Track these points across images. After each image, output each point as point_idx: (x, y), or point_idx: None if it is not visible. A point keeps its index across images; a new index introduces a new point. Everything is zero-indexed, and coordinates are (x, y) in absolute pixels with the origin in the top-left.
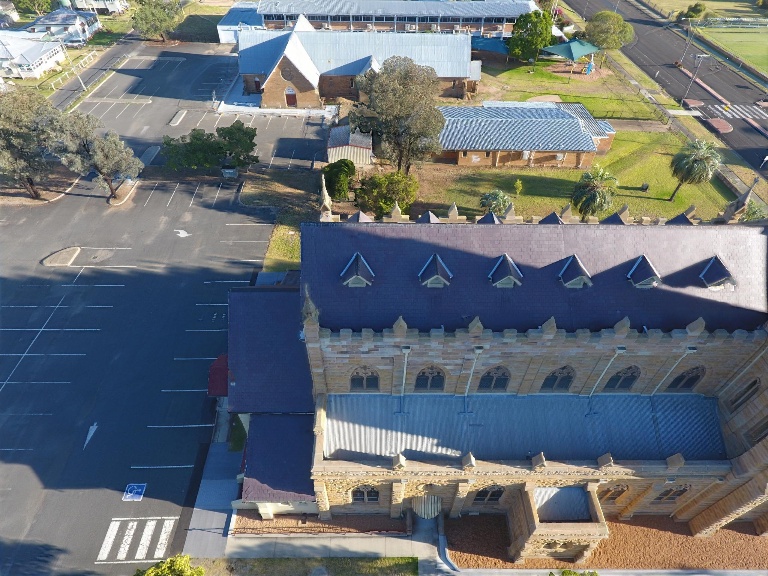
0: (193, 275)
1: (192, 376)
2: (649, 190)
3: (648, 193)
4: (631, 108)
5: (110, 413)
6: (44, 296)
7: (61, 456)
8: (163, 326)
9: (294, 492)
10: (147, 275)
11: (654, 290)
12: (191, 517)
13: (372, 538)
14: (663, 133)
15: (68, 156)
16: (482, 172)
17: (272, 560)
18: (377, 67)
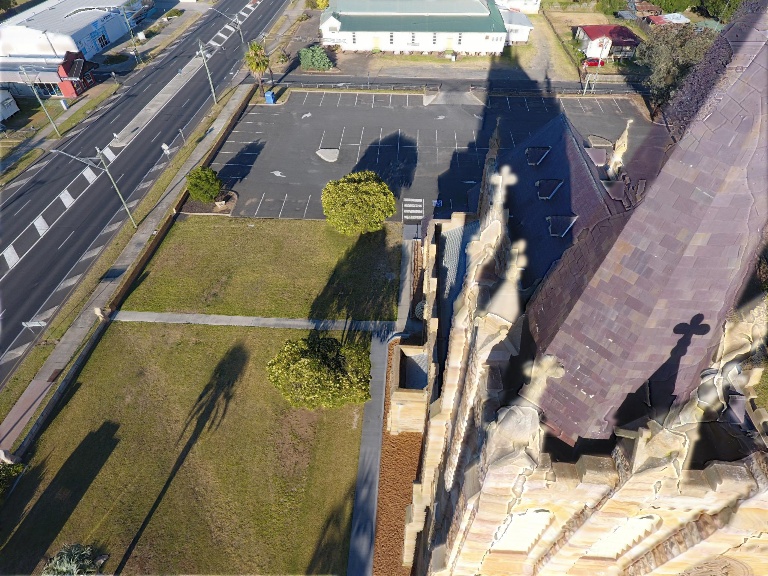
0: None
1: None
2: None
3: None
4: None
5: None
6: None
7: (456, 176)
8: None
9: None
10: None
11: None
12: None
13: None
14: None
15: (678, 92)
16: None
17: (400, 257)
18: None
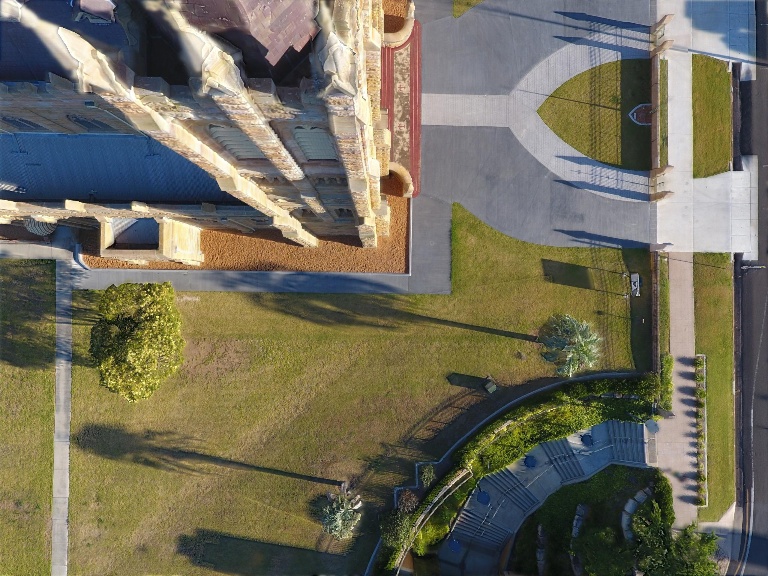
0: None
1: None
2: None
3: None
4: None
5: None
6: None
7: None
8: None
9: None
10: None
11: (115, 26)
12: None
13: (17, 244)
14: None
15: None
16: None
17: None
18: None
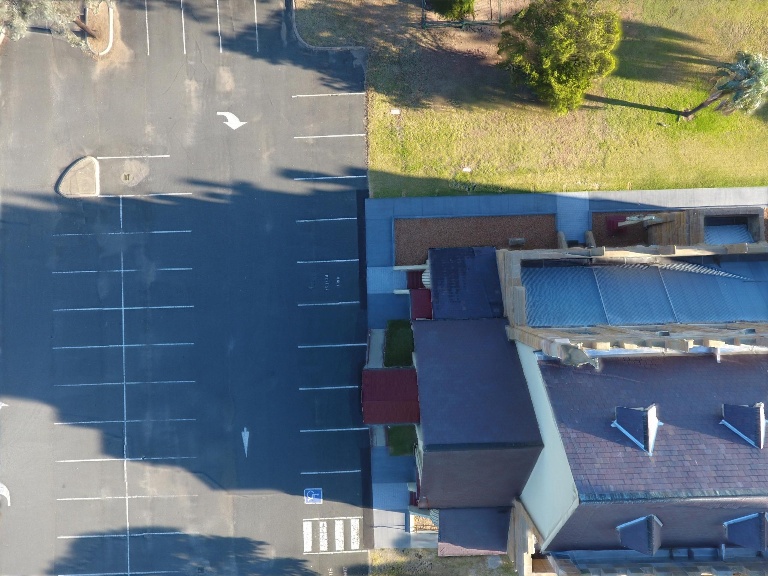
0: (276, 209)
1: (327, 370)
2: None
3: None
4: None
5: (255, 417)
6: (96, 254)
7: (228, 464)
8: (268, 299)
9: (486, 550)
10: (213, 210)
11: None
12: (373, 517)
13: None
14: None
15: None
16: None
17: None
18: None
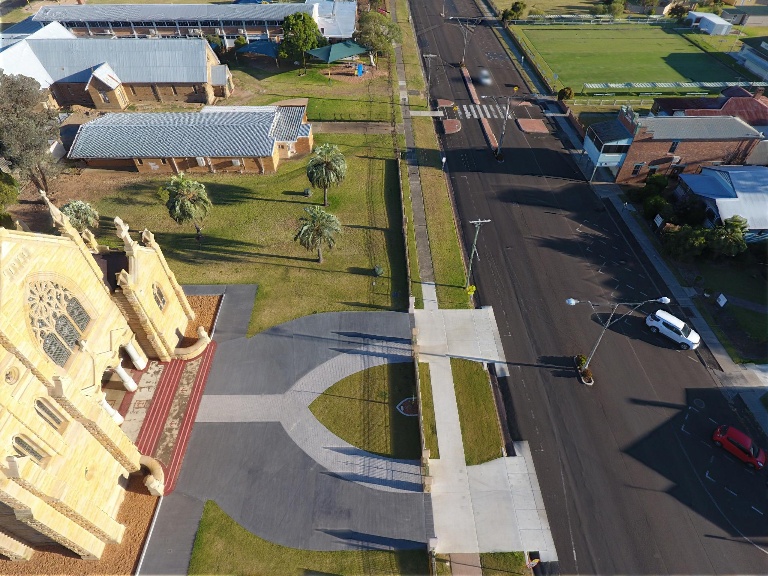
0: None
1: None
2: (313, 195)
3: (309, 198)
4: (371, 110)
5: None
6: None
7: None
8: None
9: None
10: None
11: None
12: None
13: None
14: (383, 135)
15: None
16: (156, 179)
17: None
18: (107, 74)
